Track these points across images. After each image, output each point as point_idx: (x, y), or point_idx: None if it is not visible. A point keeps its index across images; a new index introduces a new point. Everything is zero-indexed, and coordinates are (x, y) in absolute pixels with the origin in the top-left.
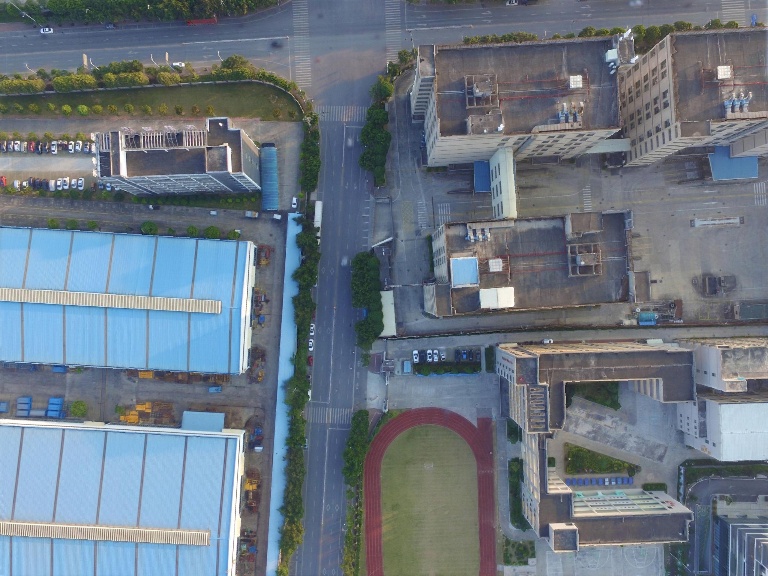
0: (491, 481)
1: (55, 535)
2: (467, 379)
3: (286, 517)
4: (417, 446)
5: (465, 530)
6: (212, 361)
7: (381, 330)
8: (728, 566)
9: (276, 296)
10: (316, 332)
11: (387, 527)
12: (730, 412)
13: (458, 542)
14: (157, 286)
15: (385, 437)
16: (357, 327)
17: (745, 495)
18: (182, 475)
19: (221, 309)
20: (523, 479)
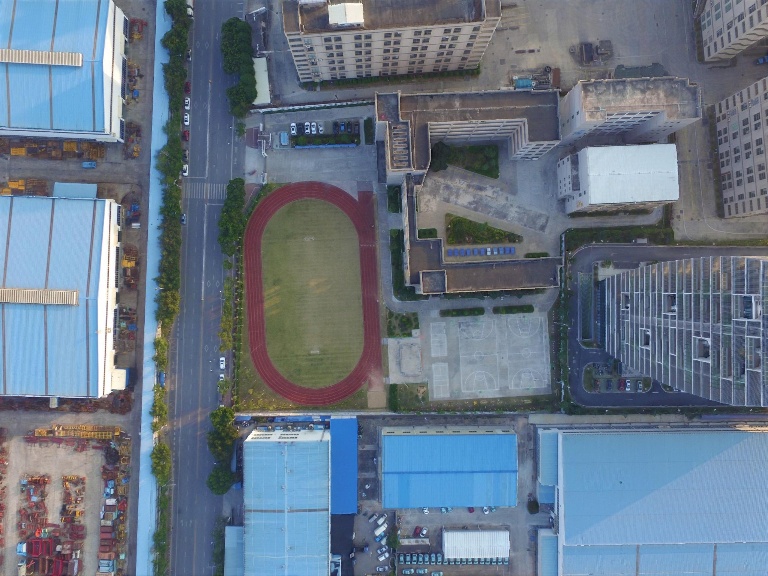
0: (373, 255)
1: None
2: (346, 152)
3: (160, 283)
4: (298, 220)
5: (348, 304)
6: (76, 118)
7: (253, 94)
8: (605, 321)
9: (150, 71)
10: (192, 107)
11: (269, 302)
12: (597, 154)
13: (341, 316)
14: (16, 40)
15: (265, 212)
16: (228, 91)
17: (627, 262)
18: (49, 236)
19: (82, 62)
20: (404, 249)
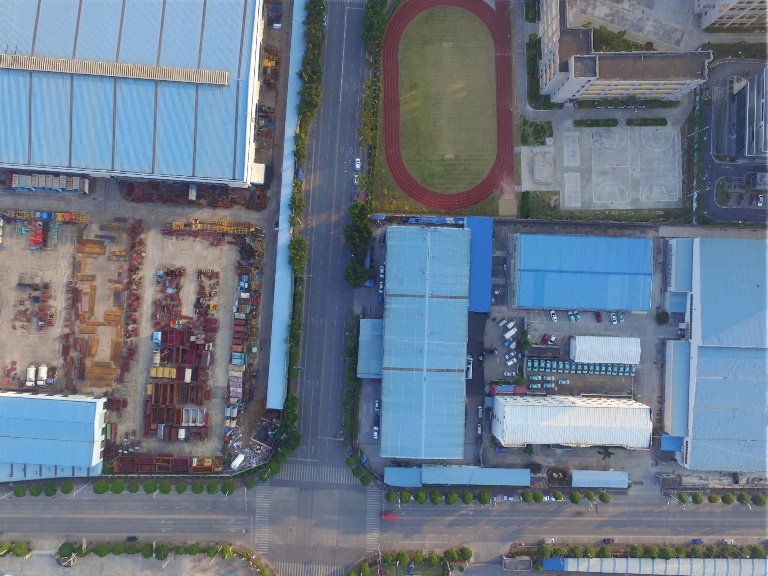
0: (509, 64)
1: (75, 69)
2: None
3: (305, 75)
4: (435, 27)
5: (483, 112)
6: None
7: None
8: (746, 125)
9: None
10: None
11: (405, 107)
12: None
13: (476, 123)
14: None
15: (403, 17)
16: None
17: None
18: (202, 19)
19: None
20: (541, 56)
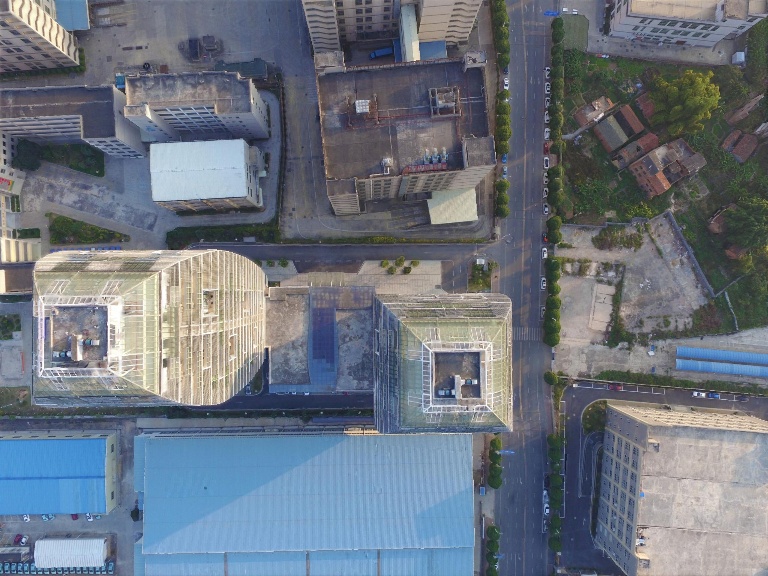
0: None
1: None
2: None
3: None
4: None
5: None
6: None
7: None
8: None
9: None
10: None
11: None
12: (160, 151)
13: None
14: None
15: None
16: None
17: None
18: None
19: None
20: None
